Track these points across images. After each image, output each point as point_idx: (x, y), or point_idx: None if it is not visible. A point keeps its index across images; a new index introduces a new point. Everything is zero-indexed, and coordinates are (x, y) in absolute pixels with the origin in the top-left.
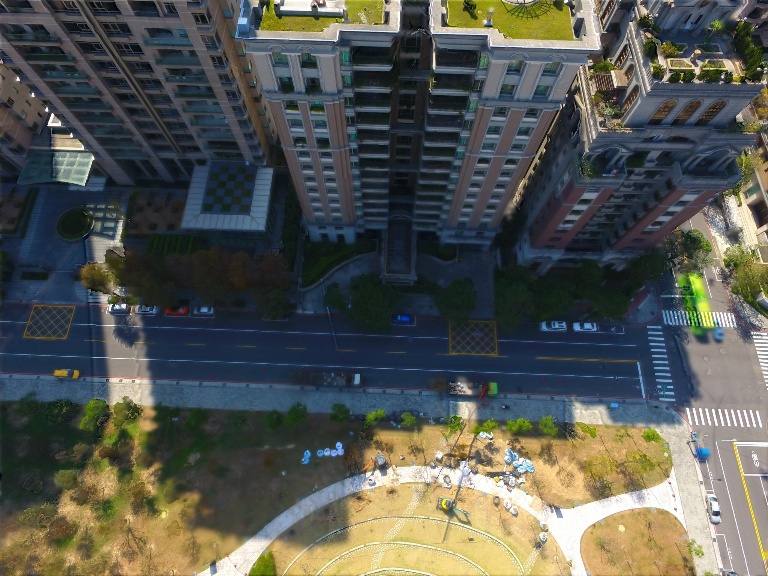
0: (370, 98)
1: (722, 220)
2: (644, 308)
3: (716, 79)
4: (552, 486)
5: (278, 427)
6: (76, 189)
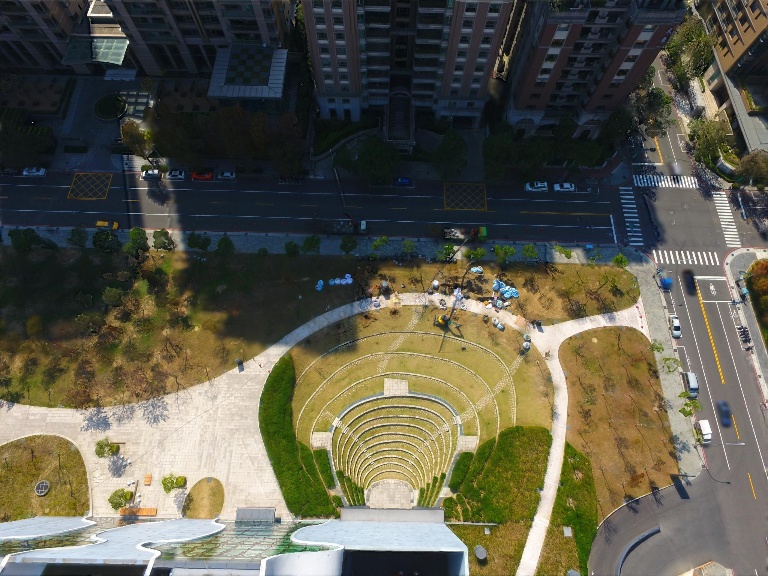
0: None
1: (688, 104)
2: (617, 173)
3: None
4: (534, 308)
5: None
6: (110, 79)
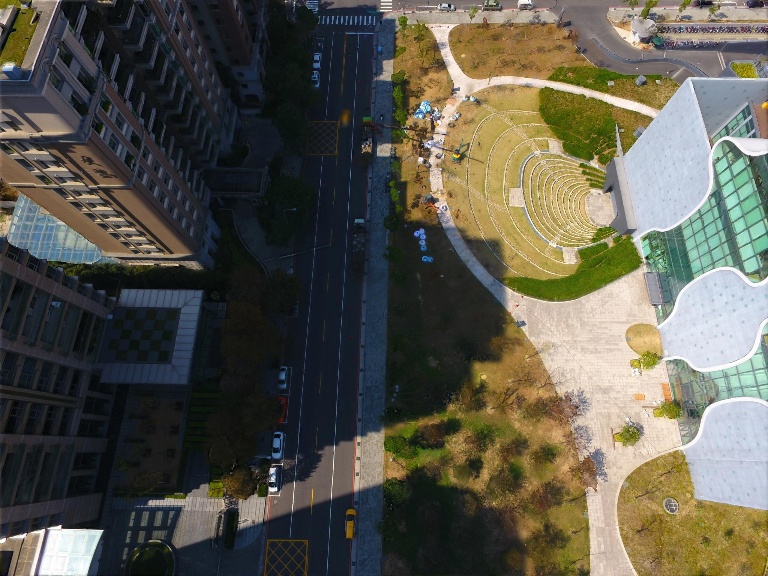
0: None
1: None
2: None
3: None
4: None
5: None
6: None
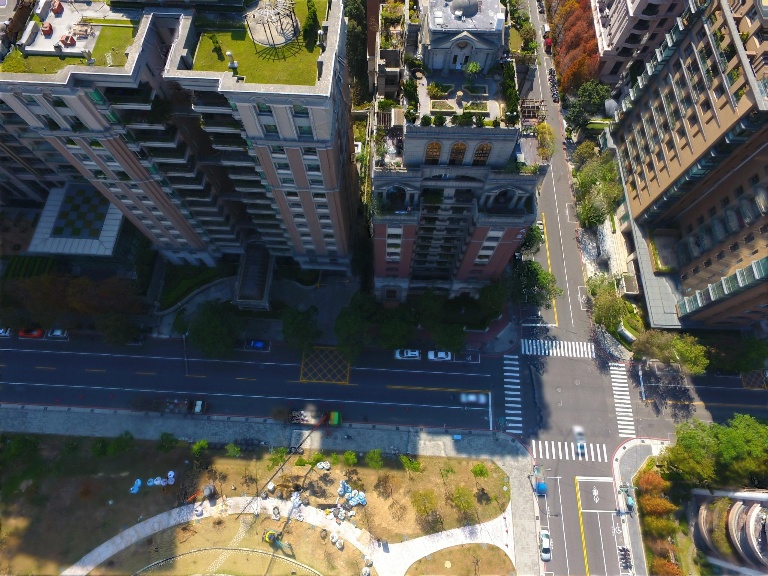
0: (152, 133)
1: (595, 247)
2: (503, 337)
3: (467, 123)
4: (383, 519)
5: (107, 455)
6: None
